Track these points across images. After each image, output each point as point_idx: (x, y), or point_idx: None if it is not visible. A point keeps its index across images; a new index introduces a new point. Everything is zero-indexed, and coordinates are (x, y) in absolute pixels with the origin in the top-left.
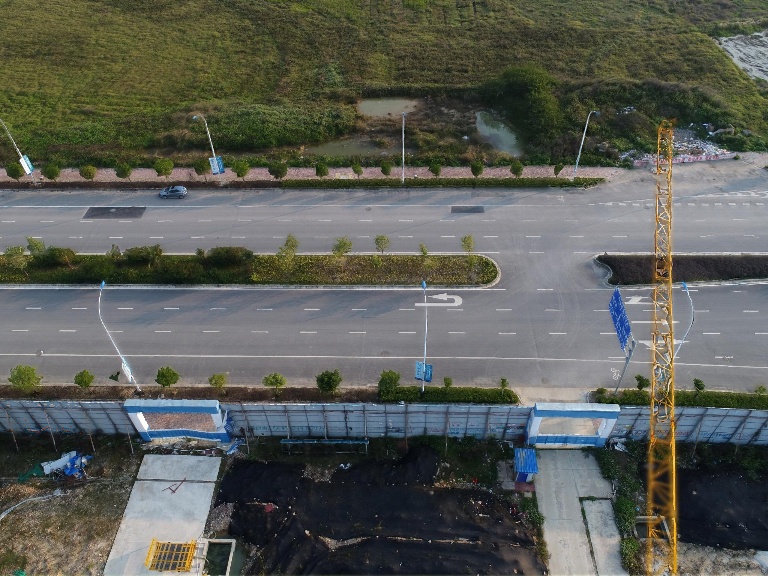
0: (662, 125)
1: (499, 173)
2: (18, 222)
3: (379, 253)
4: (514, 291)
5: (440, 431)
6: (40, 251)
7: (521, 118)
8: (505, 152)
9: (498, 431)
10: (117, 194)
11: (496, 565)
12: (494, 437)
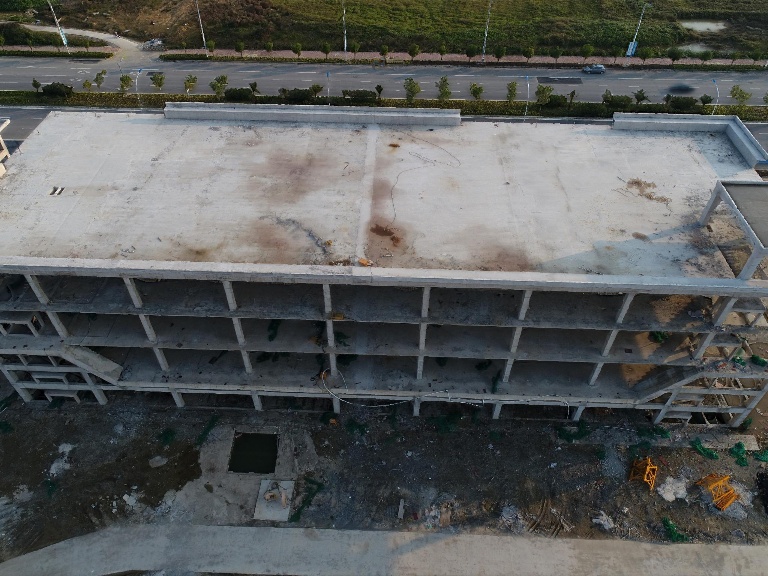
0: None
1: None
2: (492, 84)
3: None
4: None
5: None
6: None
7: None
8: None
9: None
10: (549, 70)
11: None
12: None
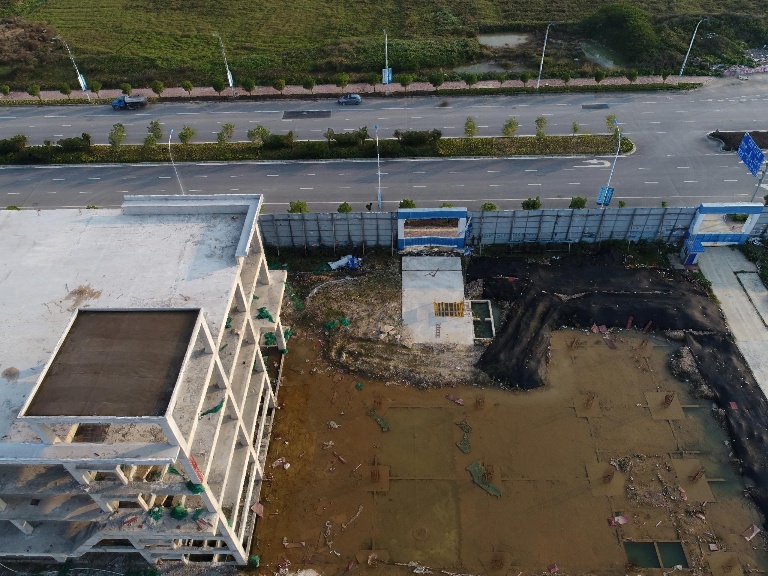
0: (741, 46)
1: (614, 82)
2: (231, 122)
3: (534, 135)
4: (649, 157)
5: (622, 235)
6: (266, 136)
7: (621, 44)
8: None
9: (666, 234)
10: (302, 103)
11: (686, 304)
12: (662, 239)
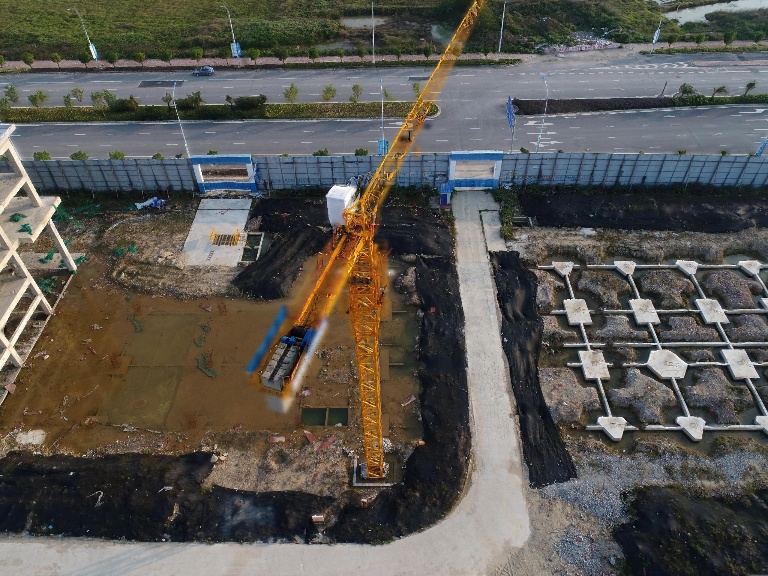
0: (570, 28)
1: None
2: (90, 90)
3: None
4: (449, 120)
5: (393, 181)
6: (113, 100)
7: None
8: (451, 45)
9: (430, 180)
10: (161, 74)
11: (424, 234)
12: (428, 185)
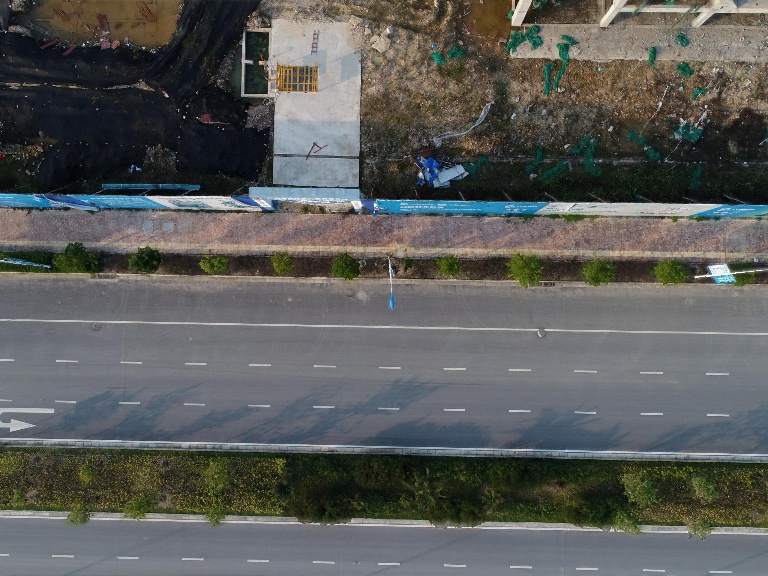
0: None
1: None
2: None
3: (103, 518)
4: None
5: None
6: None
7: None
8: None
9: None
10: None
11: None
12: None
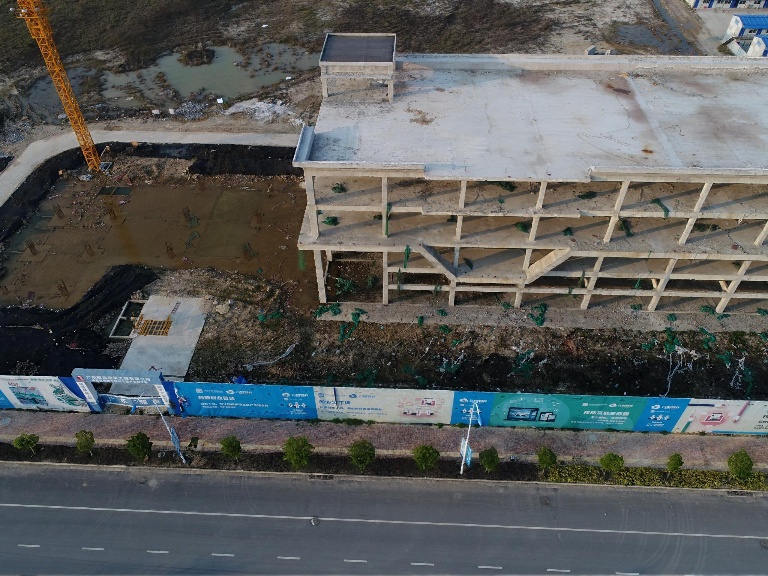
0: None
1: None
2: None
3: None
4: None
5: None
6: None
7: None
8: None
9: None
10: None
11: None
12: None
